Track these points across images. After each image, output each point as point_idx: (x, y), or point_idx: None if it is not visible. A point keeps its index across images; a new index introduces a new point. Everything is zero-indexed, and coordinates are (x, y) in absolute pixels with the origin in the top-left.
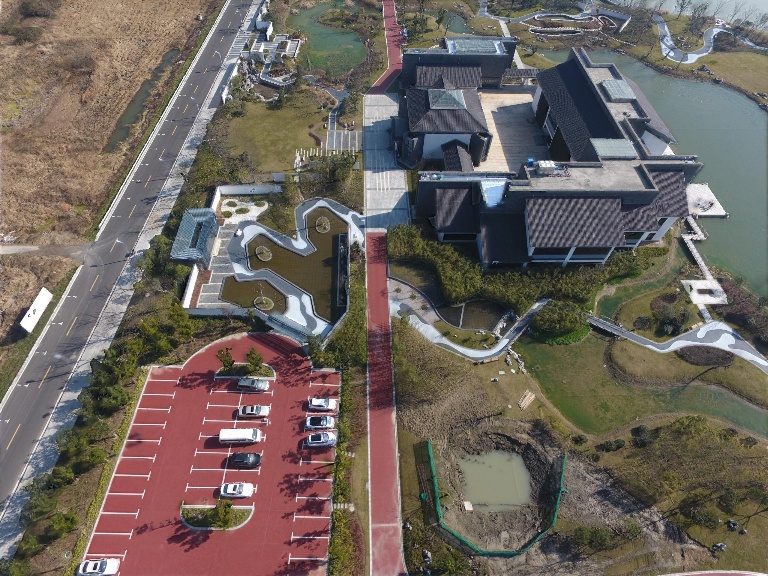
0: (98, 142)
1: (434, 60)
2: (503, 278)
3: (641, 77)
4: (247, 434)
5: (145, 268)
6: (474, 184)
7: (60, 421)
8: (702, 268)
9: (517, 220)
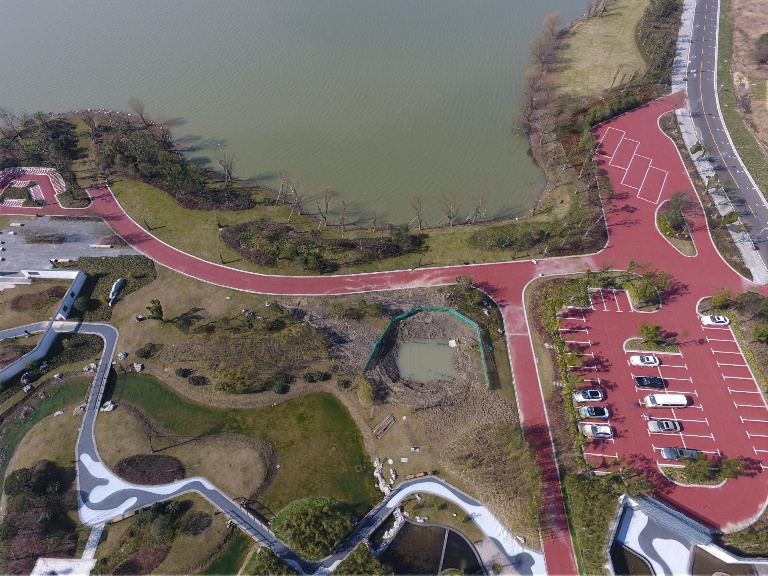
0: None
1: None
2: None
3: None
4: (661, 397)
5: None
6: None
7: None
8: None
9: None
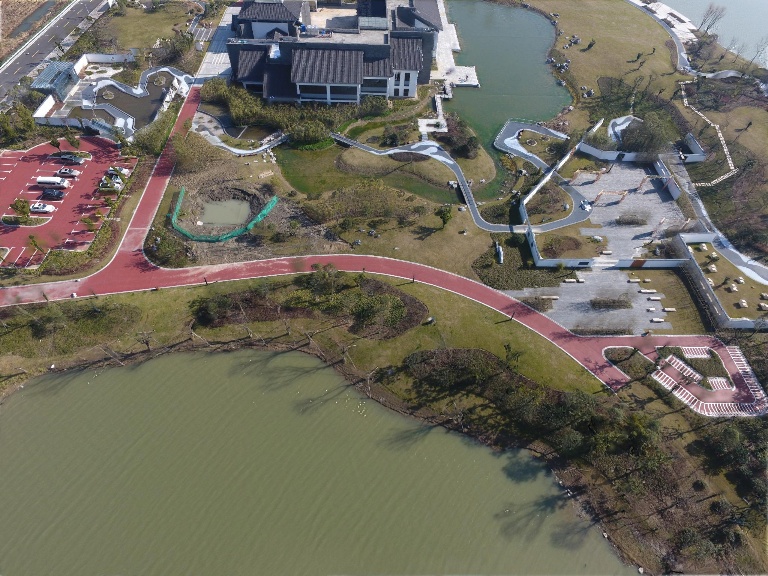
0: (4, 30)
1: None
2: (277, 108)
3: (465, 2)
4: (56, 179)
5: (13, 97)
6: (268, 47)
7: None
8: (438, 113)
9: None
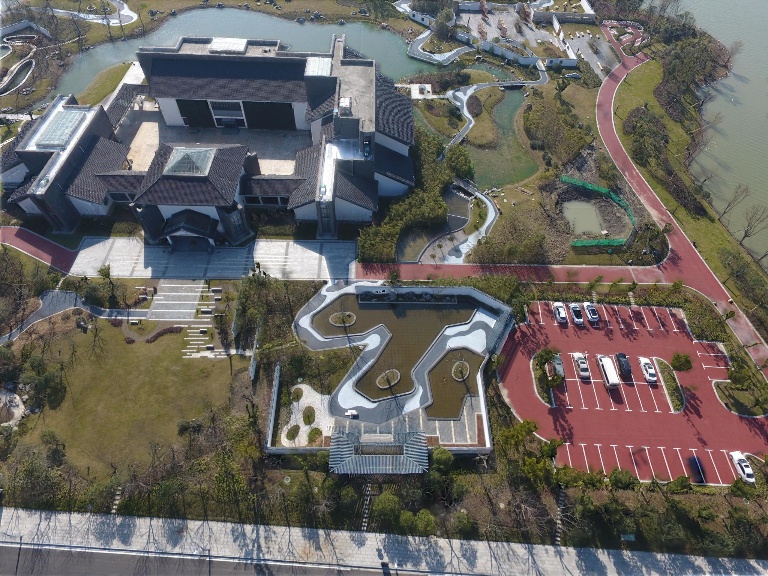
0: None
1: (67, 172)
2: None
3: None
4: (609, 361)
5: None
6: None
7: (642, 572)
8: (400, 86)
9: (380, 149)
